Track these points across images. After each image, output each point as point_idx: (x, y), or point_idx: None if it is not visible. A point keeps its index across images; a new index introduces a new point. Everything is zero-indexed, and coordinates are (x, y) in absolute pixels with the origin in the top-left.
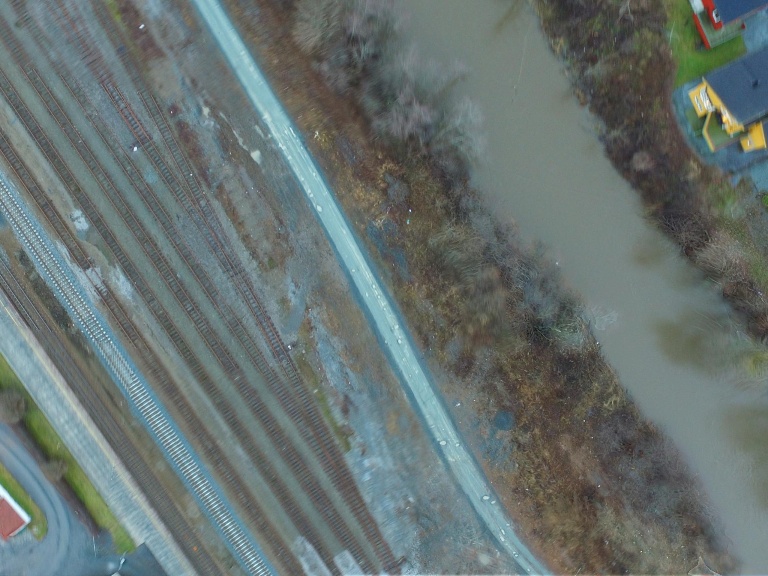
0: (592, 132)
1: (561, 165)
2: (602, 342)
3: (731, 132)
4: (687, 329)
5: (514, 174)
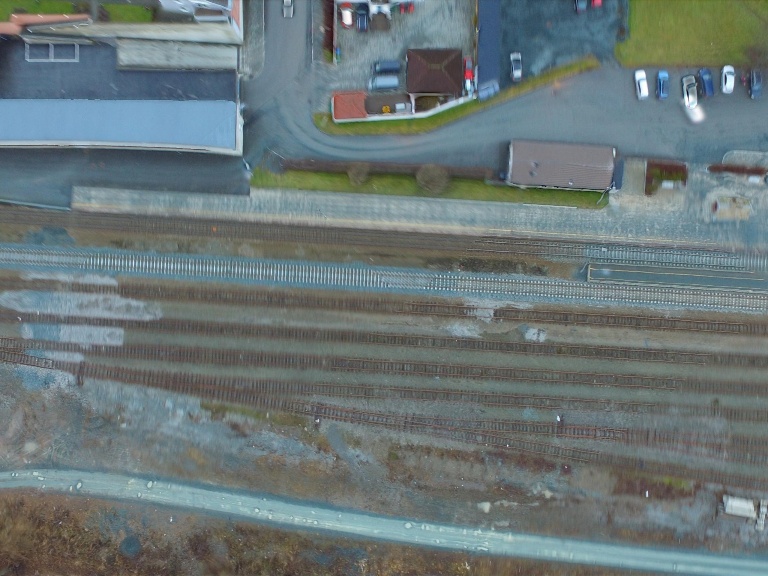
0: None
1: None
2: None
3: None
4: None
5: None
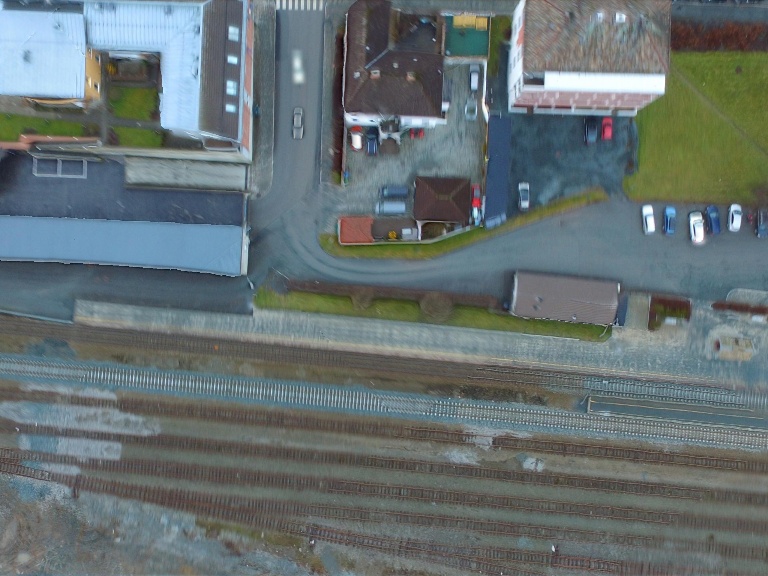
0: None
1: None
2: None
3: None
4: None
5: None
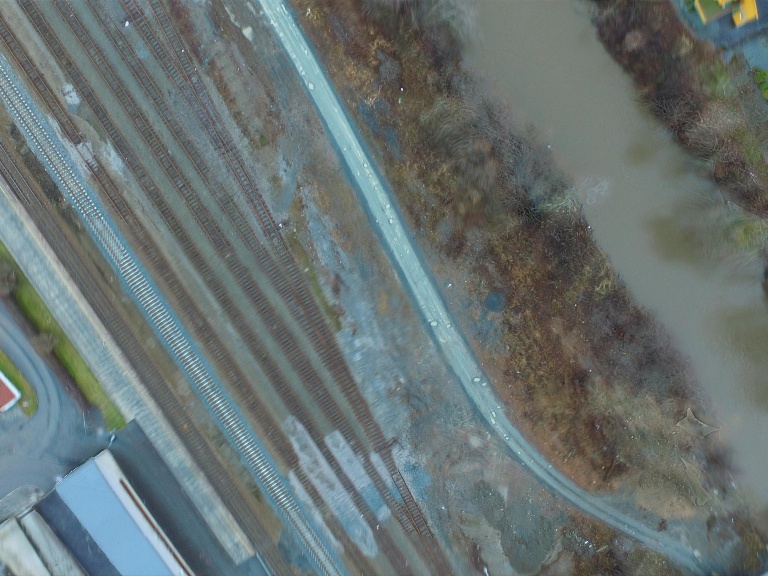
0: (585, 14)
1: (553, 47)
2: (594, 226)
3: (723, 2)
4: (679, 208)
5: (506, 52)
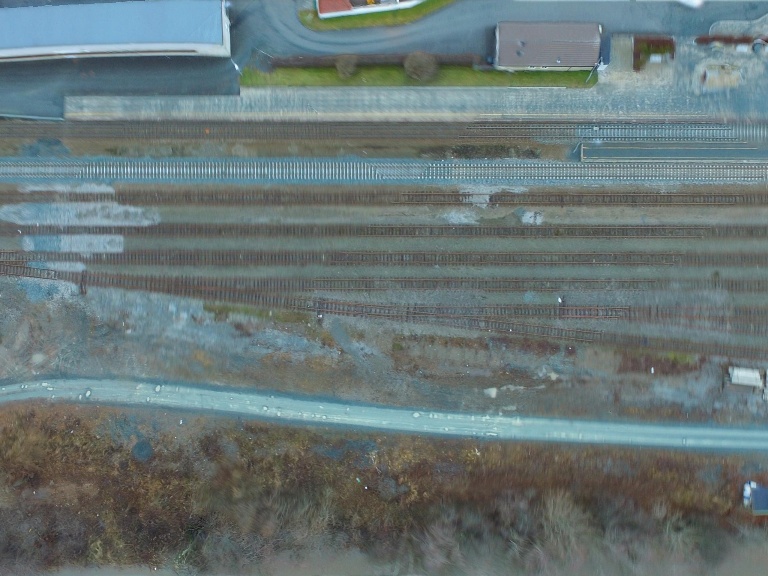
0: None
1: None
2: (154, 573)
3: None
4: None
5: None
